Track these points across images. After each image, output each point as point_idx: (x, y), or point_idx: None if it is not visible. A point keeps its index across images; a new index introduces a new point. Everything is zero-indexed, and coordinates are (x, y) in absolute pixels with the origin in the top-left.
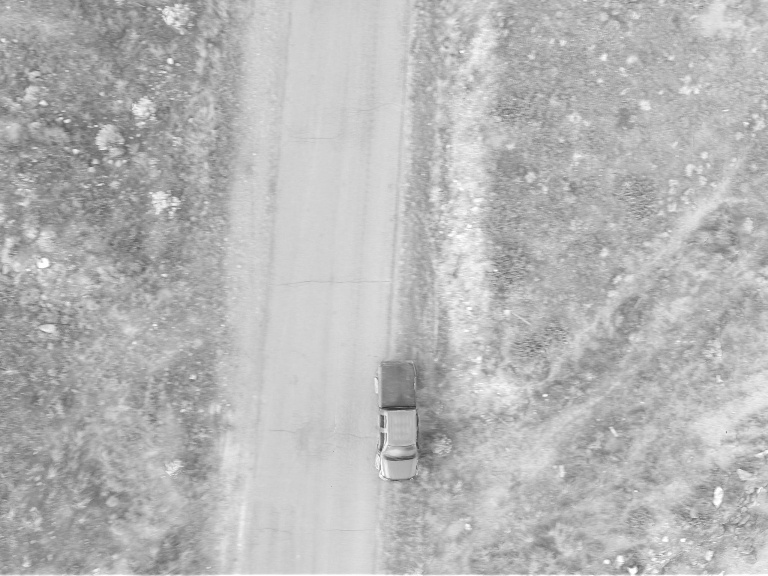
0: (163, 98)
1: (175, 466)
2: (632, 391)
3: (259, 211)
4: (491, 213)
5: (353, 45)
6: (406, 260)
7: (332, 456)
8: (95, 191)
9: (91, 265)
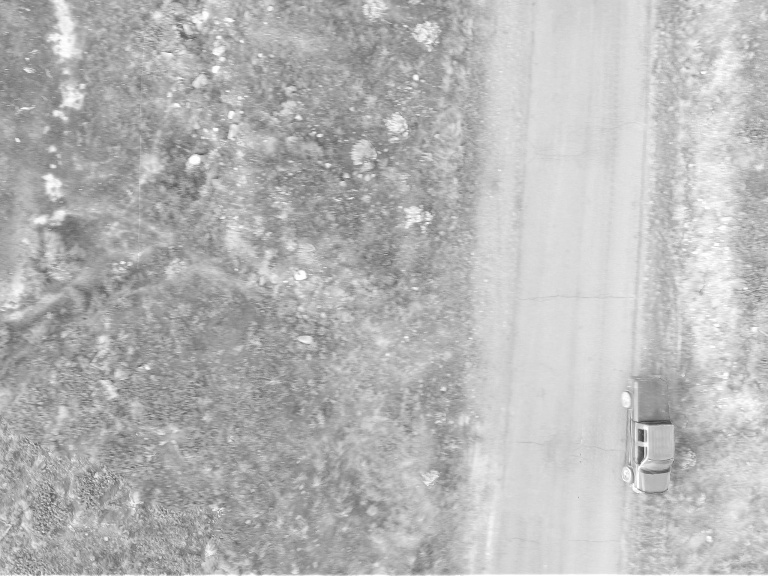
0: (411, 114)
1: (433, 476)
2: None
3: (506, 226)
4: (740, 232)
5: (596, 64)
6: (650, 277)
7: (579, 468)
8: (347, 205)
9: (345, 277)
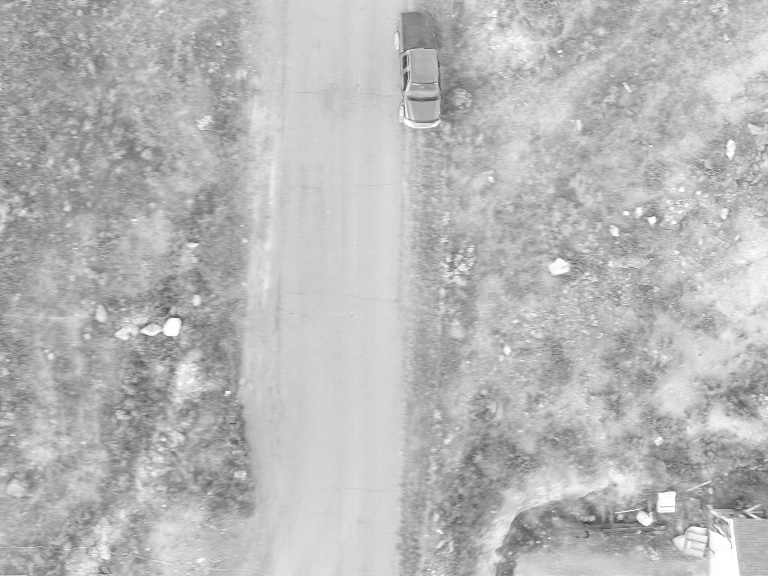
0: None
1: (206, 119)
2: (643, 48)
3: None
4: None
5: None
6: None
7: (357, 115)
8: None
9: None
